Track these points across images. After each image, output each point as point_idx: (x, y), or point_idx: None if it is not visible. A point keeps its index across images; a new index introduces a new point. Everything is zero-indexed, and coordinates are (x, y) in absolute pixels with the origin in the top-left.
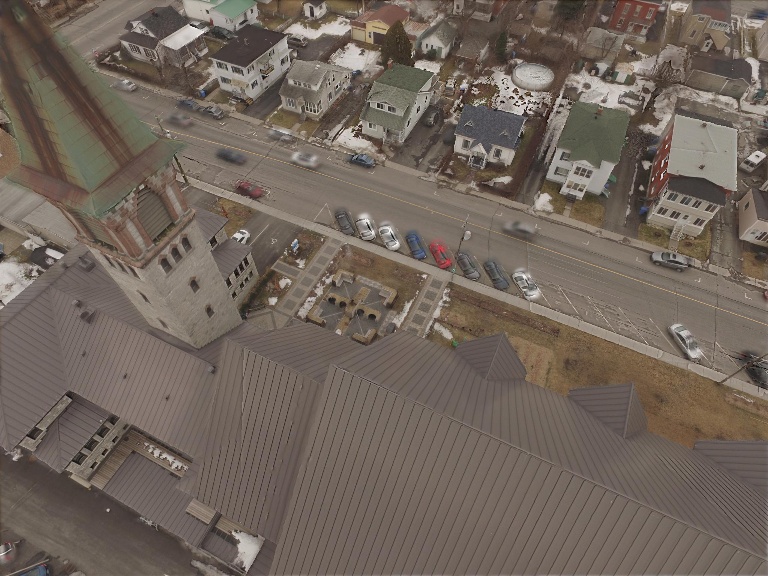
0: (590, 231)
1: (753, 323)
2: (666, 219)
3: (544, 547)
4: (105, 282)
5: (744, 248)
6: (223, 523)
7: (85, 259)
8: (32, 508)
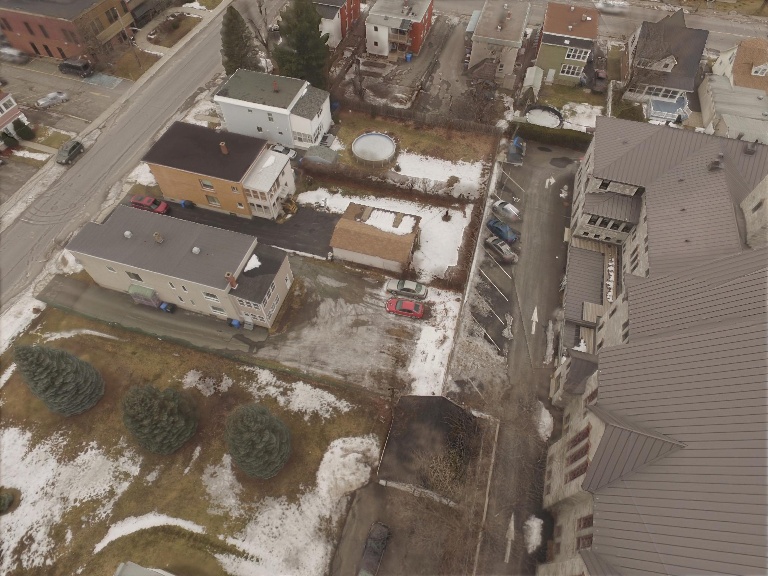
0: None
1: None
2: None
3: None
4: (742, 168)
5: None
6: (585, 331)
7: (755, 145)
8: (540, 217)
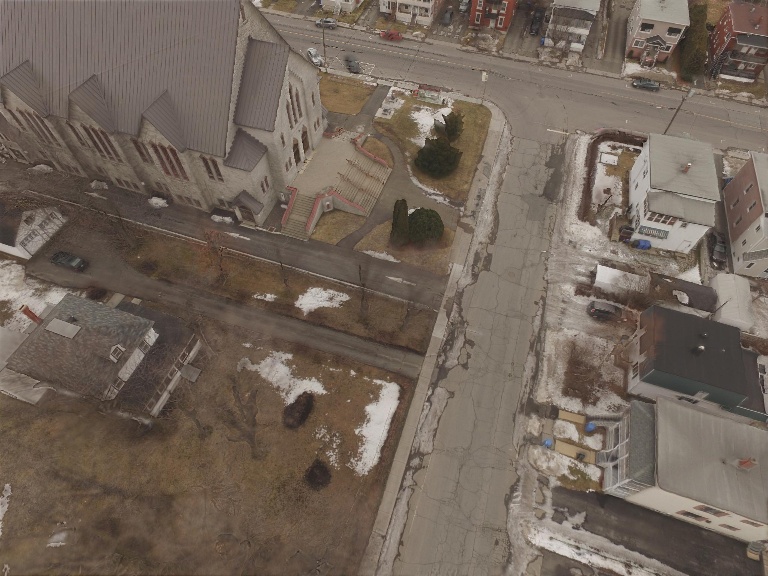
0: (283, 15)
1: (365, 48)
2: (330, 1)
3: (61, 3)
4: None
5: (381, 16)
6: None
7: None
8: None
